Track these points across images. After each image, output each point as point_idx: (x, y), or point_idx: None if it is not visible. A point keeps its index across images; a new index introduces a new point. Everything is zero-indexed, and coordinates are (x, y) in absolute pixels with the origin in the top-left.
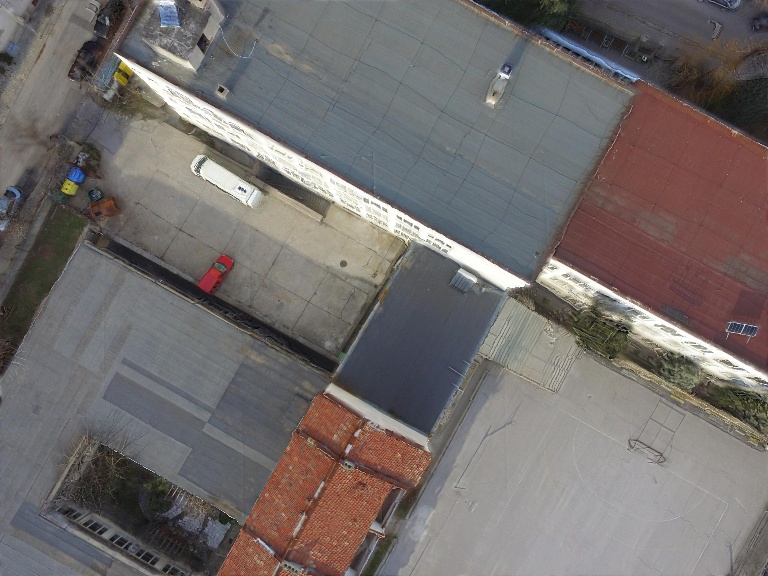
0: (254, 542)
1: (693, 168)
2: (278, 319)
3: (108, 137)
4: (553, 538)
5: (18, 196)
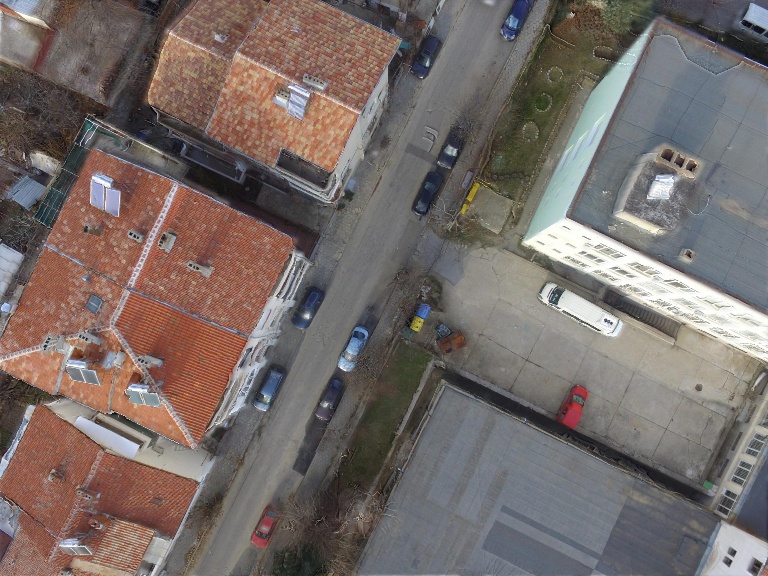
0: None
1: None
2: (636, 449)
3: (449, 268)
4: None
5: (366, 336)
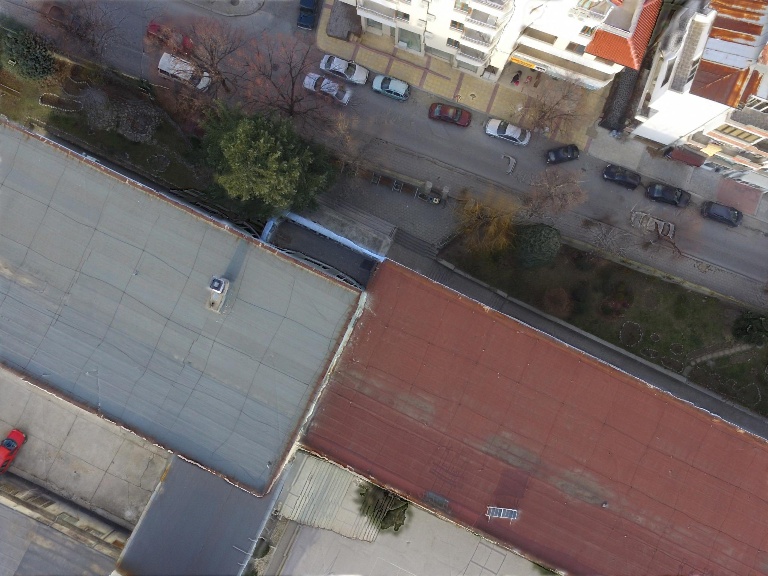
0: None
1: (448, 345)
2: (75, 491)
3: None
4: None
5: None
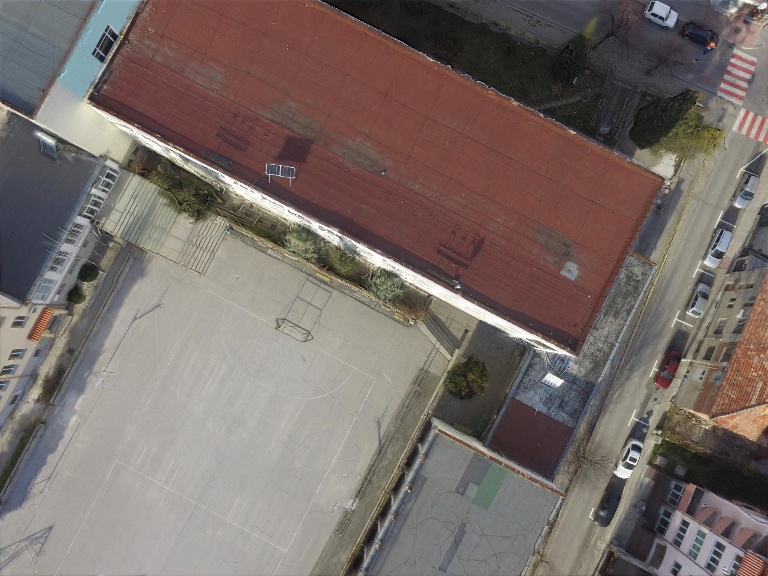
0: None
1: (241, 18)
2: None
3: None
4: (202, 419)
5: None
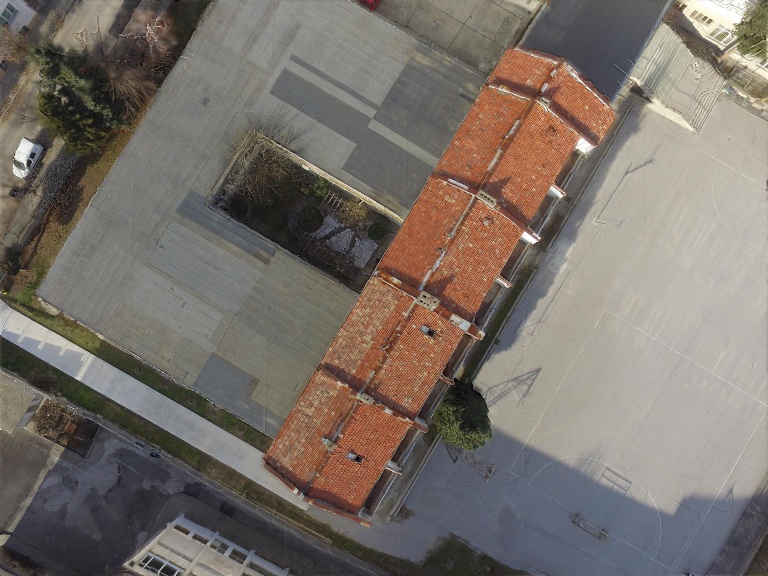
0: (444, 185)
1: None
2: (434, 40)
3: None
4: (690, 274)
5: None
